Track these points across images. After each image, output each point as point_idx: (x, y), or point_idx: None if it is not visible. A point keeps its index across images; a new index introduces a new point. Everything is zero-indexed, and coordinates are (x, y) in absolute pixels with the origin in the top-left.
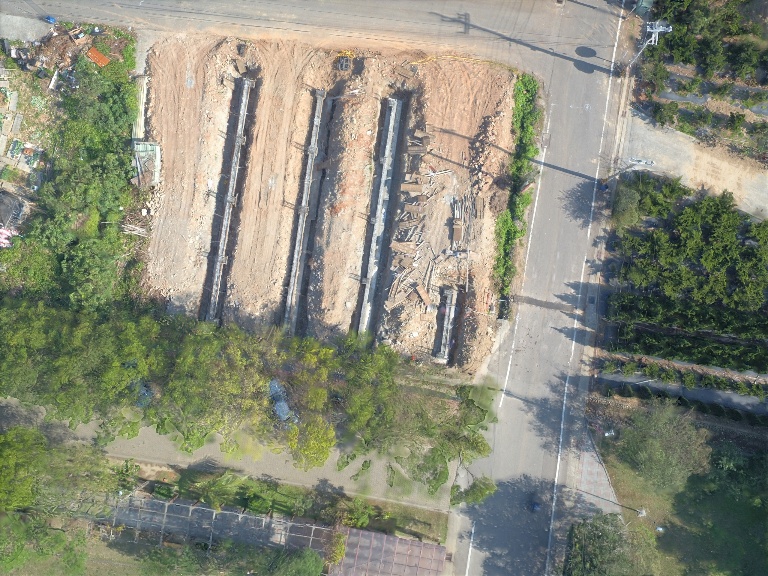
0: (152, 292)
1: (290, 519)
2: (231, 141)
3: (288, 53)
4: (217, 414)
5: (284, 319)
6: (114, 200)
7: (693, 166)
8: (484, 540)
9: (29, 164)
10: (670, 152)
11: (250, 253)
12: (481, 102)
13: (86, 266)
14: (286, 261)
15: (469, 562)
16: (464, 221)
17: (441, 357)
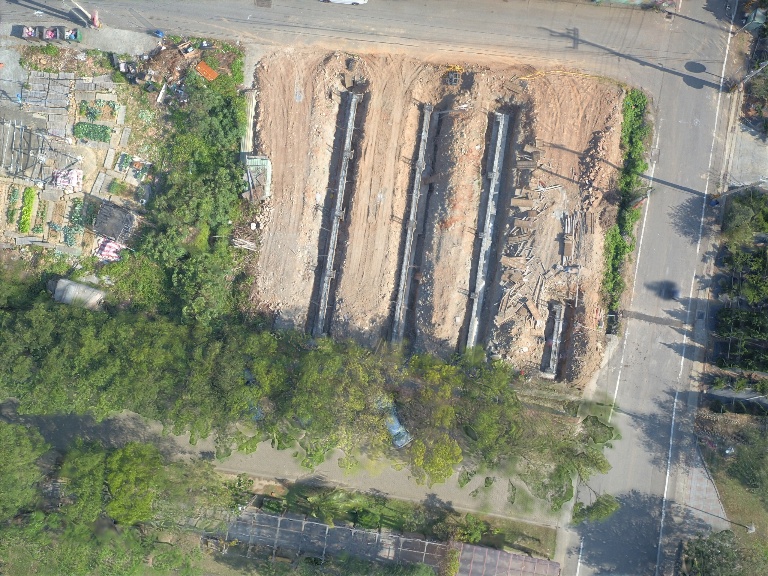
0: (261, 306)
1: (401, 534)
2: (337, 155)
3: (396, 67)
4: (342, 430)
5: (392, 333)
6: (225, 214)
7: None
8: (593, 556)
9: (137, 178)
10: None
11: (359, 267)
12: (591, 117)
13: (199, 280)
14: (394, 275)
15: None
16: (575, 236)
17: (550, 372)
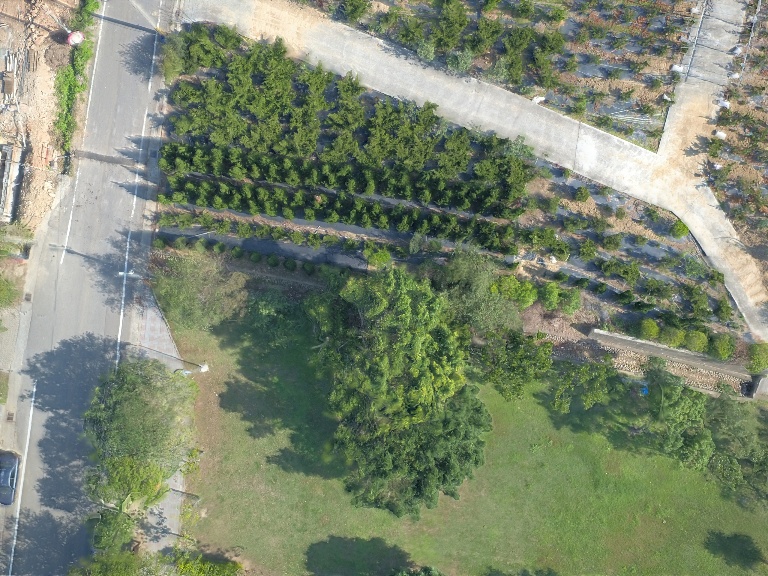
0: None
1: None
2: None
3: None
4: None
5: None
6: None
7: (252, 16)
8: (45, 399)
9: None
10: (229, 3)
11: None
12: None
13: None
14: None
15: (31, 421)
16: (16, 74)
17: (0, 214)
